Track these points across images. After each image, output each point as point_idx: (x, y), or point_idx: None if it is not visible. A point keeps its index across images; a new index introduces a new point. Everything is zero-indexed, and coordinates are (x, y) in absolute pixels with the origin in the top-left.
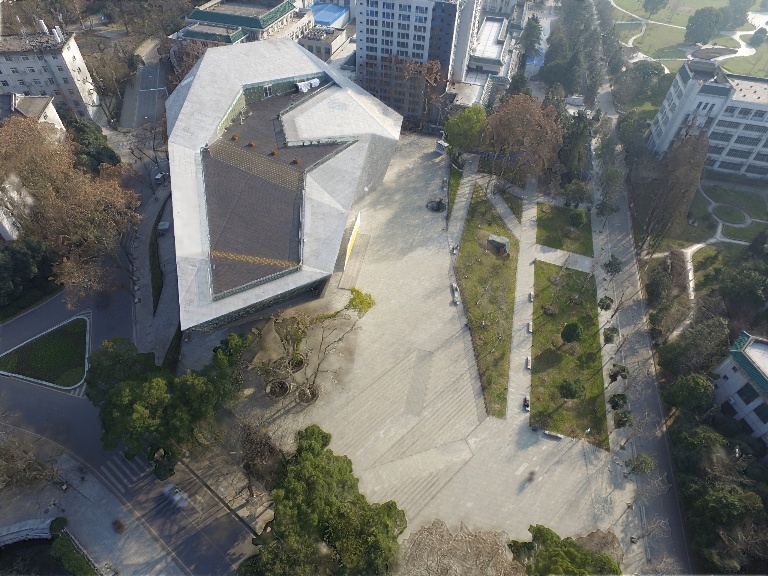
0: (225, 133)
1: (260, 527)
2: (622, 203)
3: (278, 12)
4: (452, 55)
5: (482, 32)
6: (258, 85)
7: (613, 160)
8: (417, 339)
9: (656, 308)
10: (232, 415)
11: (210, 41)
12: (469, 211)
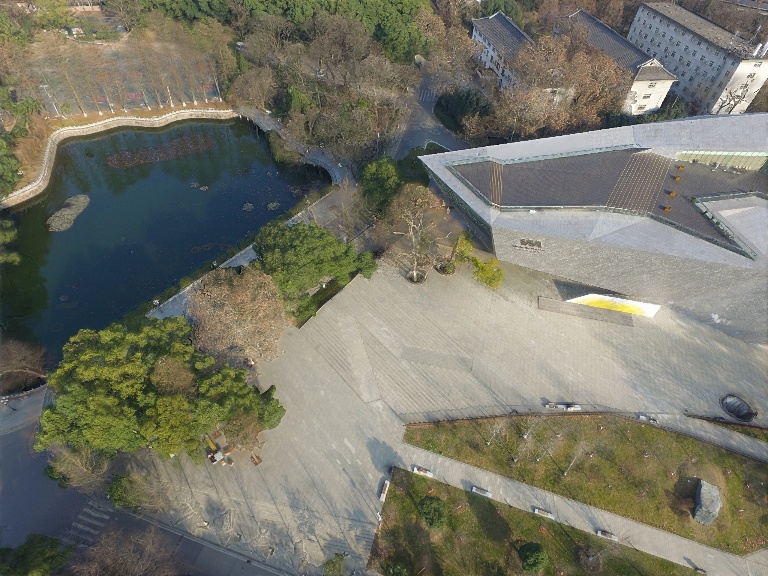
0: (686, 162)
1: None
2: None
3: None
4: None
5: None
6: None
7: None
8: (486, 359)
9: None
10: (398, 239)
11: None
12: (761, 463)
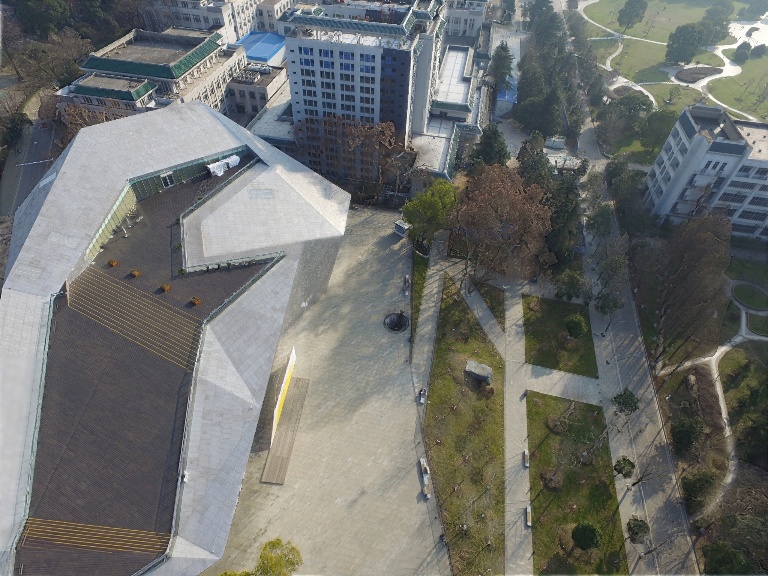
0: (100, 255)
1: None
2: (624, 288)
3: (197, 55)
4: (409, 108)
5: (445, 66)
6: (152, 175)
7: (609, 231)
8: (372, 573)
9: (686, 460)
10: None
11: (107, 98)
12: (439, 324)
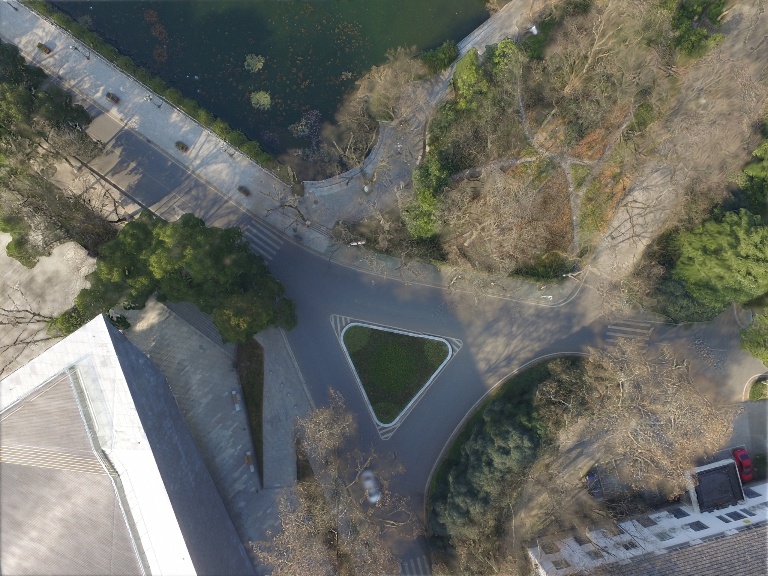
0: None
1: (116, 195)
2: None
3: None
4: None
5: None
6: None
7: None
8: None
9: None
10: None
11: None
12: None
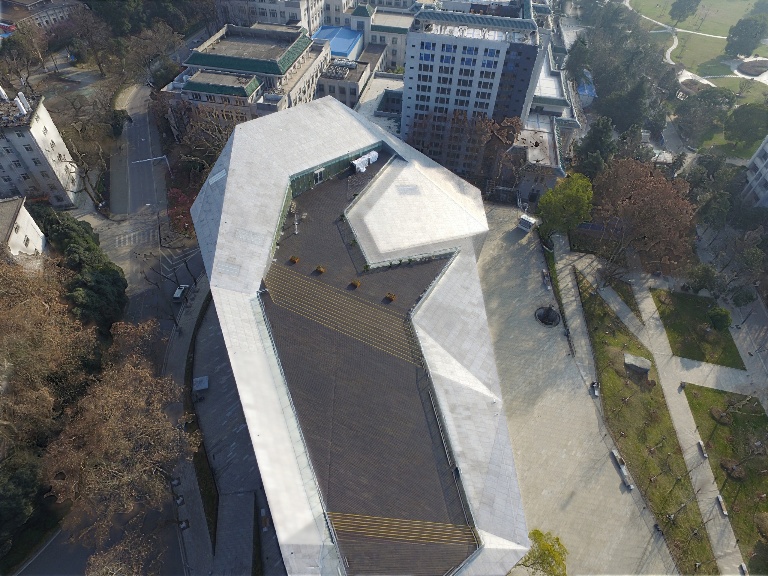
0: (278, 251)
1: None
2: None
3: (295, 50)
4: None
5: None
6: (308, 172)
7: (723, 224)
8: (599, 563)
9: None
10: None
11: (219, 95)
12: (586, 317)
